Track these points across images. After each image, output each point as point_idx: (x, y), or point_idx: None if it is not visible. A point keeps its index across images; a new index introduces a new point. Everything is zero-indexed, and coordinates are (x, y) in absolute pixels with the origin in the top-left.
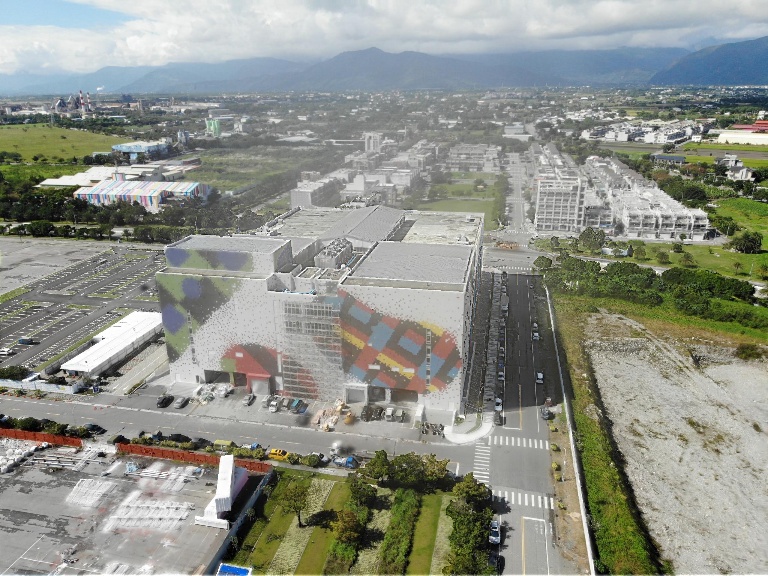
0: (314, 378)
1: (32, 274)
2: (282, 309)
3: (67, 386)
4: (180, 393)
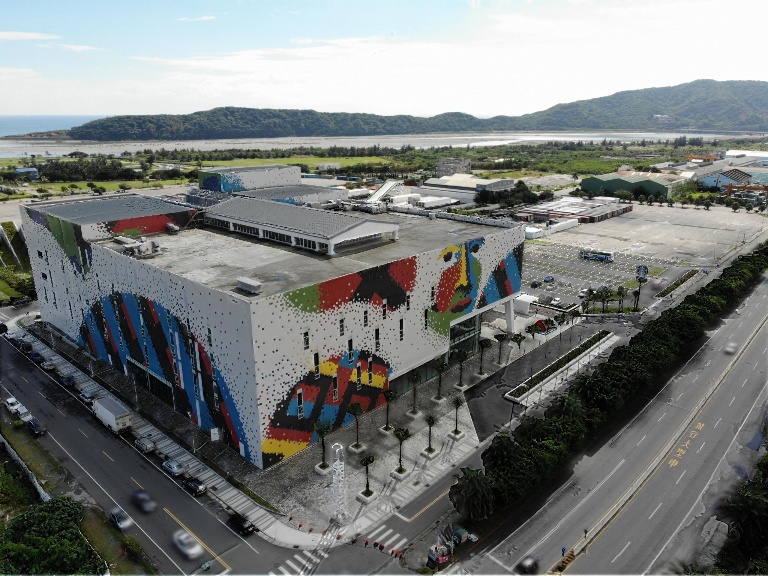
0: None
1: (600, 245)
2: None
3: None
4: None
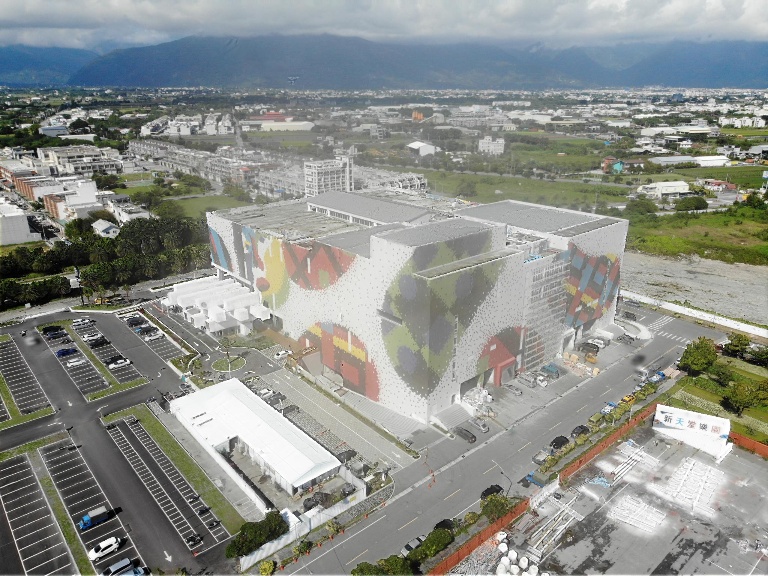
0: (543, 341)
1: None
2: (532, 279)
3: (359, 491)
4: (458, 421)
